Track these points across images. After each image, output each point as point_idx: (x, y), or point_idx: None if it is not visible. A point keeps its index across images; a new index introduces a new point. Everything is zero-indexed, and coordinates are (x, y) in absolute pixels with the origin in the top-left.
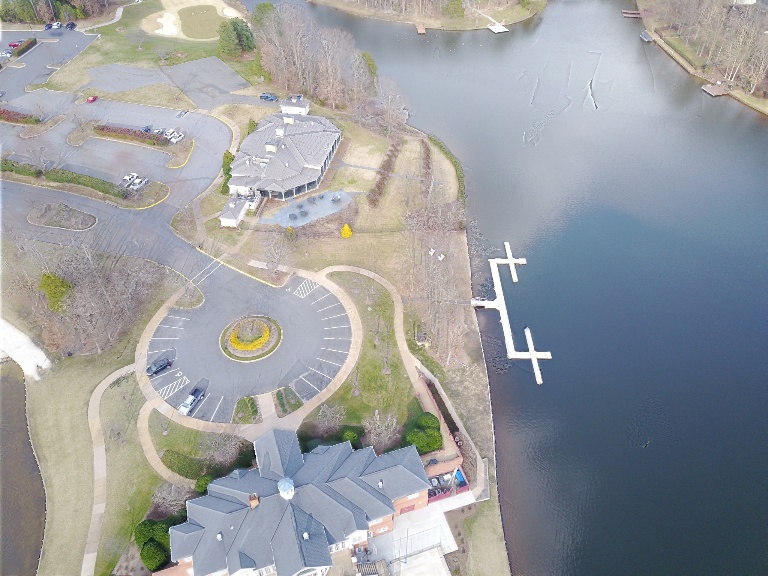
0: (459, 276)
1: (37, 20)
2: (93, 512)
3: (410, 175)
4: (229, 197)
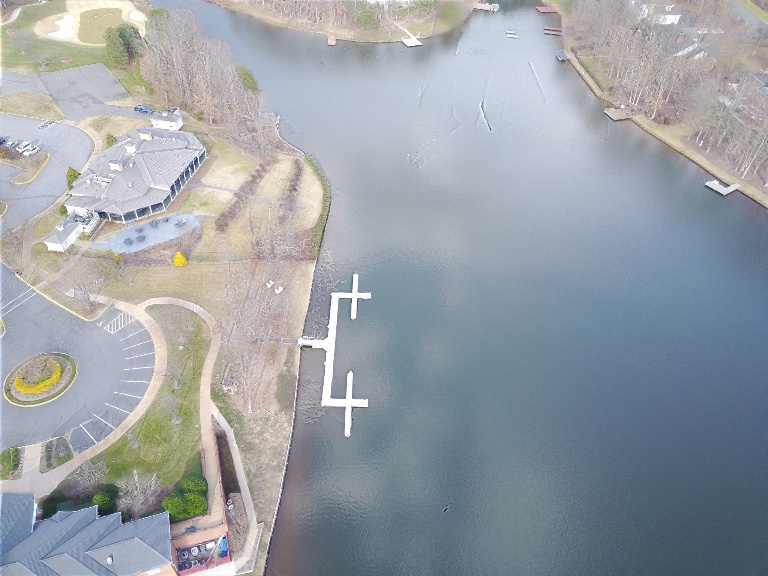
0: (294, 311)
1: None
2: None
3: (271, 198)
4: (66, 218)
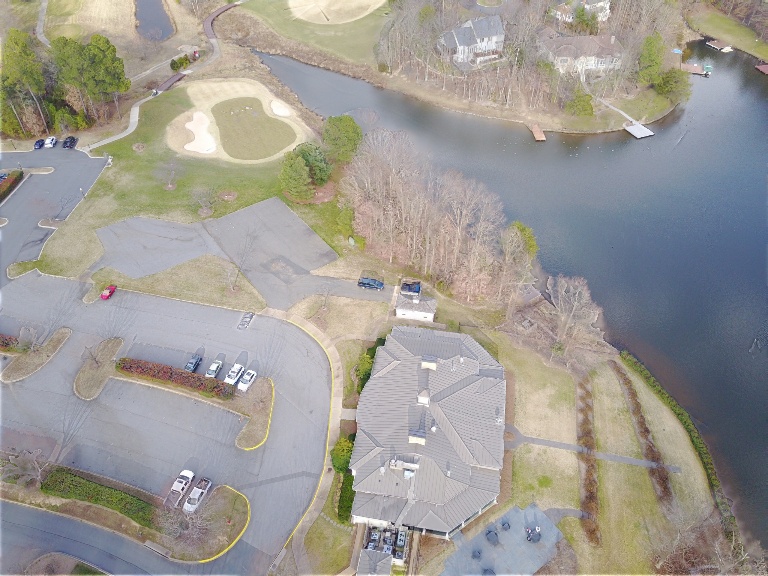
0: None
1: (23, 133)
2: None
3: (627, 455)
4: (353, 531)
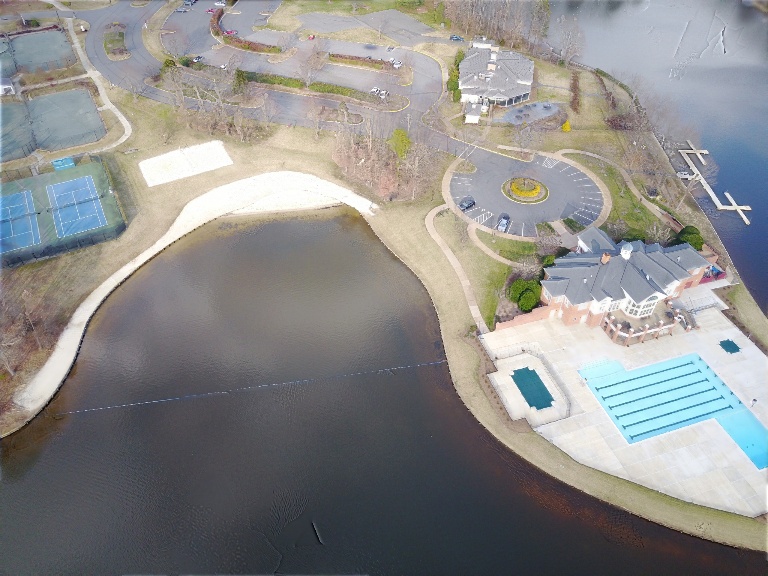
0: (660, 160)
1: None
2: (462, 285)
3: (595, 94)
4: (461, 104)
